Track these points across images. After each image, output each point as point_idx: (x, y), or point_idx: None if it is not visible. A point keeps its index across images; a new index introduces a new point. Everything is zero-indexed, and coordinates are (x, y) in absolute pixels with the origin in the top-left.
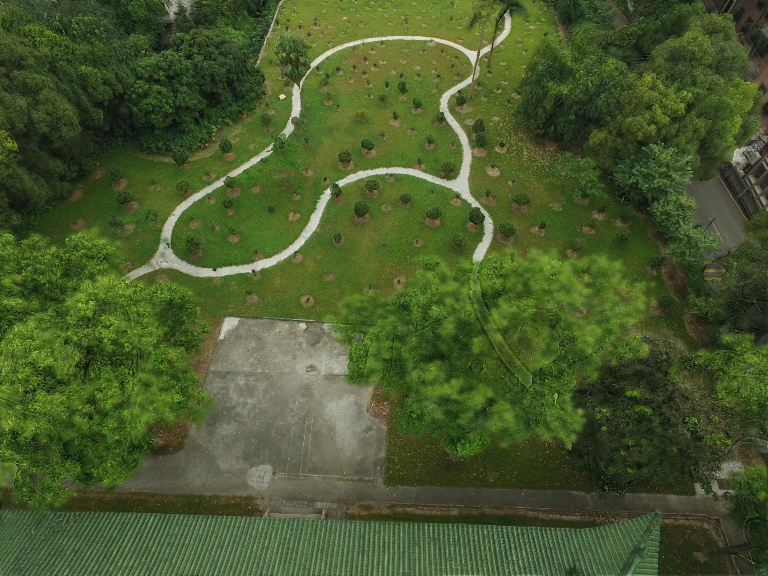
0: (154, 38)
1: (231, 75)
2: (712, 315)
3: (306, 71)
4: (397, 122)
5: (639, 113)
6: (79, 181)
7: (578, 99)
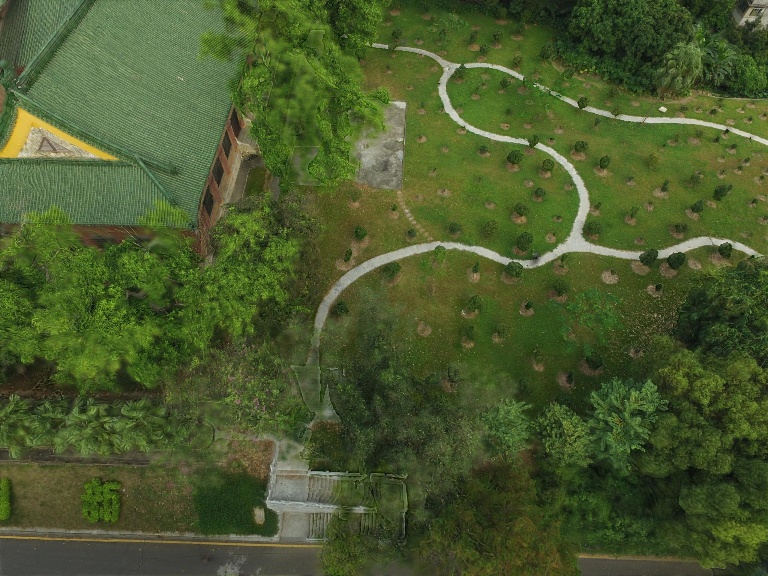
0: (707, 23)
1: (651, 53)
2: None
3: (671, 88)
4: (662, 195)
5: (710, 370)
6: (515, 20)
7: (716, 304)
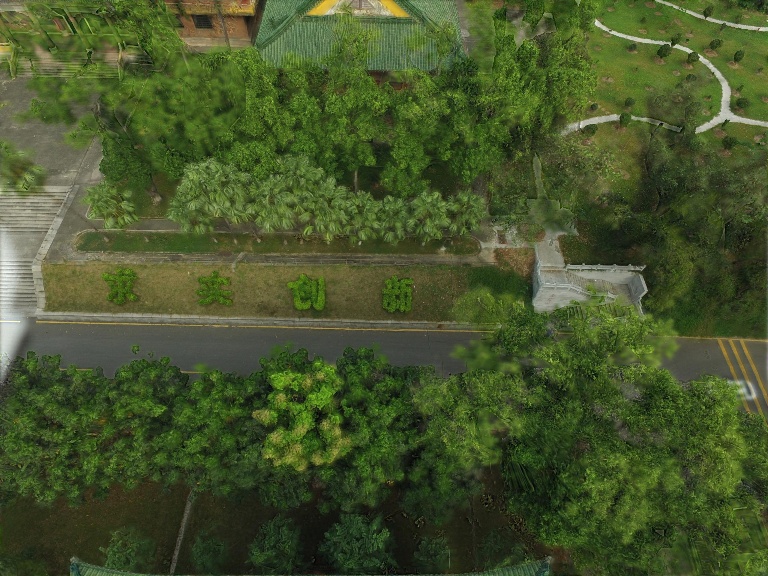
0: None
1: None
2: (650, 229)
3: None
4: None
5: None
6: None
7: None
